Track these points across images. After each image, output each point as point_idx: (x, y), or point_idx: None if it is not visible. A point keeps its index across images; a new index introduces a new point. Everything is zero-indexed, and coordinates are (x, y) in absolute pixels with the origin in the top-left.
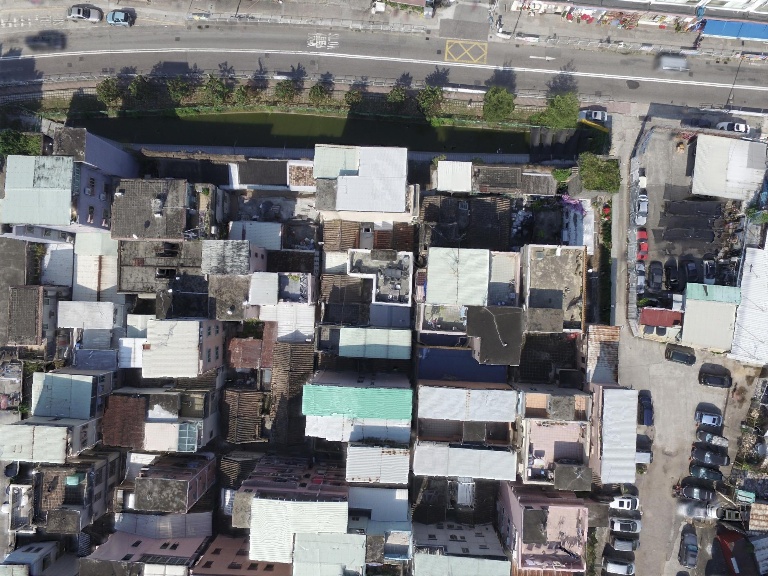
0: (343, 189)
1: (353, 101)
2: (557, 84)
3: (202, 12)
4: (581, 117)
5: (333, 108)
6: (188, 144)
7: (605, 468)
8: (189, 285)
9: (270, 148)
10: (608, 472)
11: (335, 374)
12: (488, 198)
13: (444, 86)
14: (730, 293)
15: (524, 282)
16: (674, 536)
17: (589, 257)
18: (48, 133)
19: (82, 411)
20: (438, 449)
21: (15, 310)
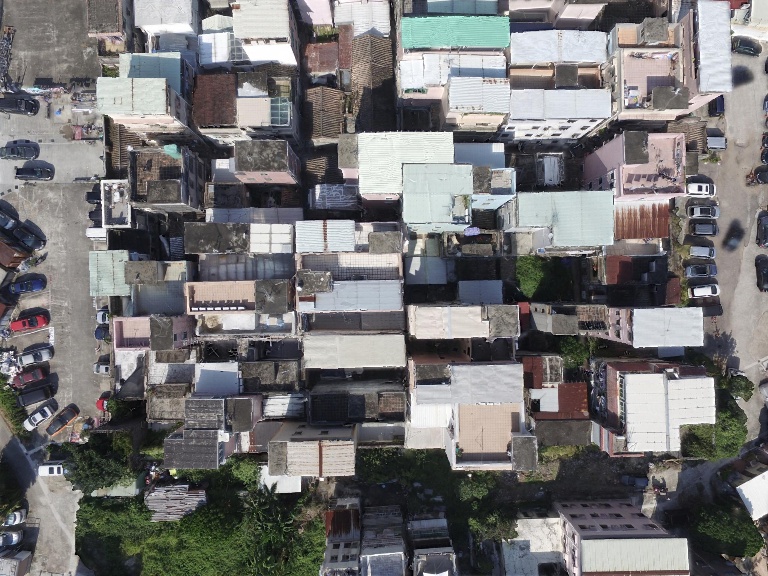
0: None
1: None
2: None
3: None
4: None
5: None
6: None
7: (703, 77)
8: None
9: None
10: (706, 81)
11: None
12: None
13: None
14: None
15: None
16: (751, 223)
17: None
18: None
19: None
20: (533, 92)
21: None
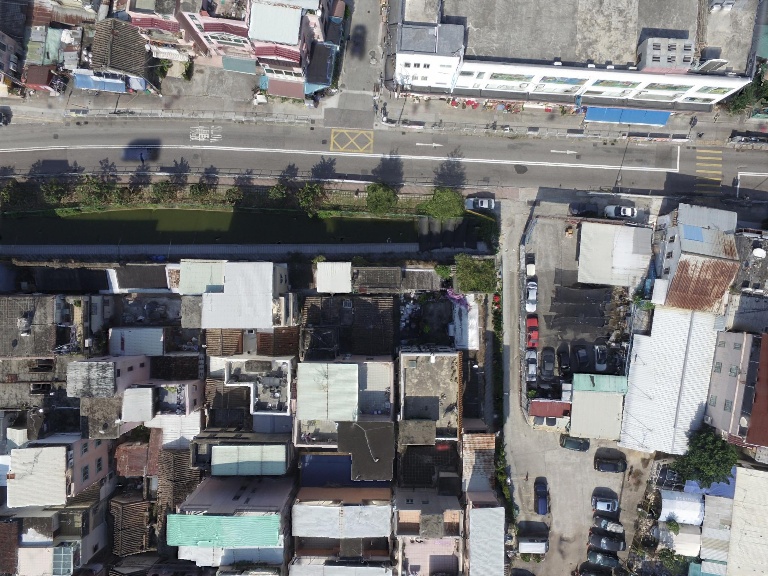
0: (208, 307)
1: (234, 199)
2: (445, 171)
3: (80, 108)
4: (469, 205)
5: (218, 202)
6: (71, 244)
7: None
8: (65, 400)
9: (155, 245)
10: None
11: (218, 484)
12: (369, 298)
13: (330, 177)
14: (617, 383)
15: (400, 390)
16: None
17: (475, 352)
18: None
19: None
20: (313, 568)
21: None
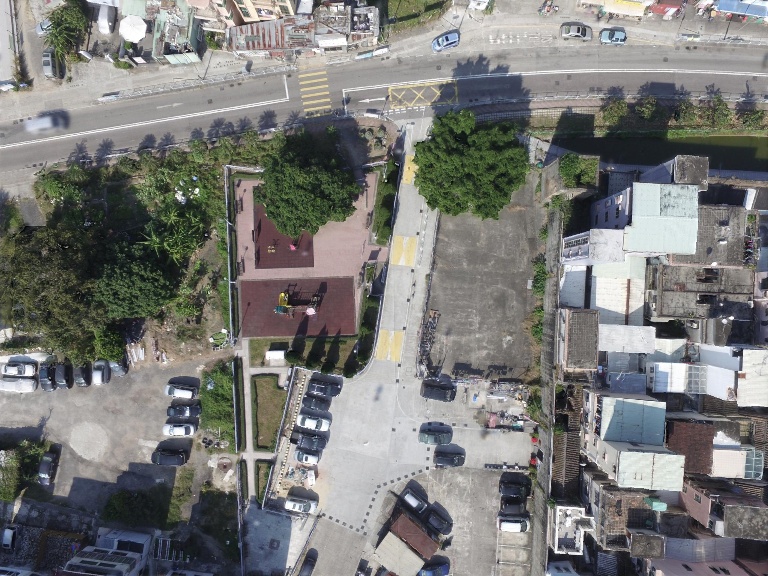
0: None
1: None
2: None
3: (692, 33)
4: None
5: None
6: None
7: None
8: (730, 311)
9: (756, 172)
10: None
11: None
12: None
13: None
14: None
15: None
16: None
17: None
18: (535, 152)
19: (655, 437)
20: None
21: (575, 334)
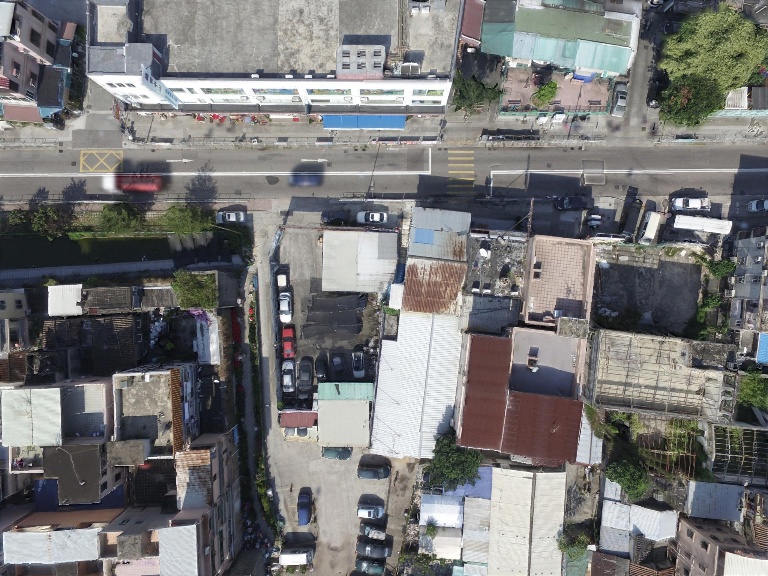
0: None
1: None
2: (196, 186)
3: None
4: (218, 219)
5: None
6: None
7: None
8: None
9: None
10: None
11: None
12: (102, 319)
13: (81, 198)
14: (362, 390)
15: None
16: None
17: (218, 366)
18: None
19: None
20: None
21: None
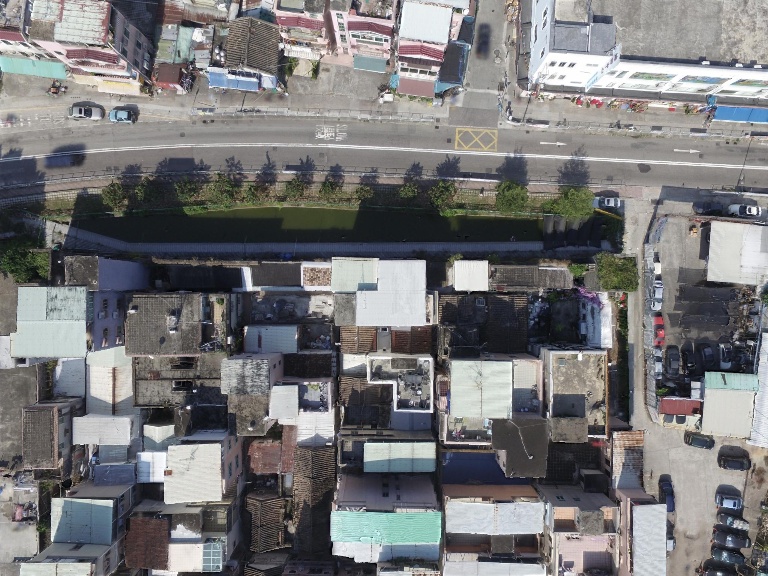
0: (362, 304)
1: (365, 197)
2: (568, 169)
3: (207, 107)
4: (594, 203)
5: (344, 201)
6: (197, 242)
7: None
8: (206, 397)
9: (281, 243)
10: None
11: (358, 481)
12: (506, 296)
13: (455, 175)
14: (748, 381)
15: (546, 388)
16: None
17: None
18: (53, 235)
19: (103, 536)
20: (467, 564)
21: (29, 433)
